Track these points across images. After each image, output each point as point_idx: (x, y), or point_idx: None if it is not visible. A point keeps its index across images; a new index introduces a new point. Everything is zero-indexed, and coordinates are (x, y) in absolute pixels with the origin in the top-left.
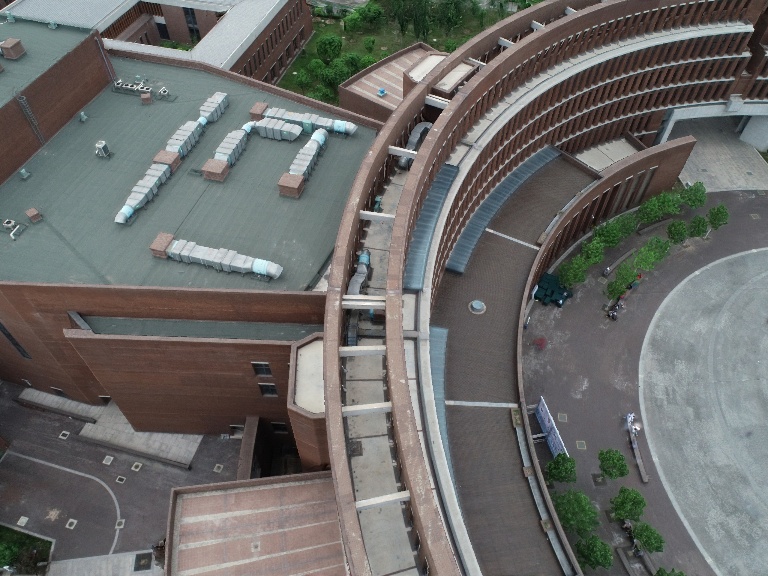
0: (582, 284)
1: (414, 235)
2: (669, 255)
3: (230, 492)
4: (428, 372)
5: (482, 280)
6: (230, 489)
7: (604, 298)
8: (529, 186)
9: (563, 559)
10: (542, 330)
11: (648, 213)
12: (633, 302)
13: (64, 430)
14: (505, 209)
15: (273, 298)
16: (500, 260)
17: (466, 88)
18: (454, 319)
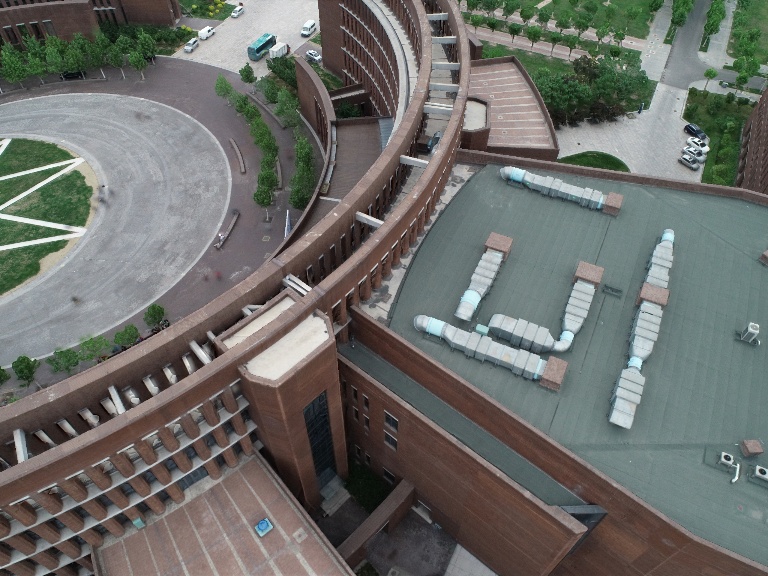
0: None
1: None
2: None
3: None
4: (398, 118)
5: None
6: None
7: None
8: None
9: (333, 131)
10: None
11: None
12: None
13: None
14: None
15: None
16: None
17: (268, 271)
18: None
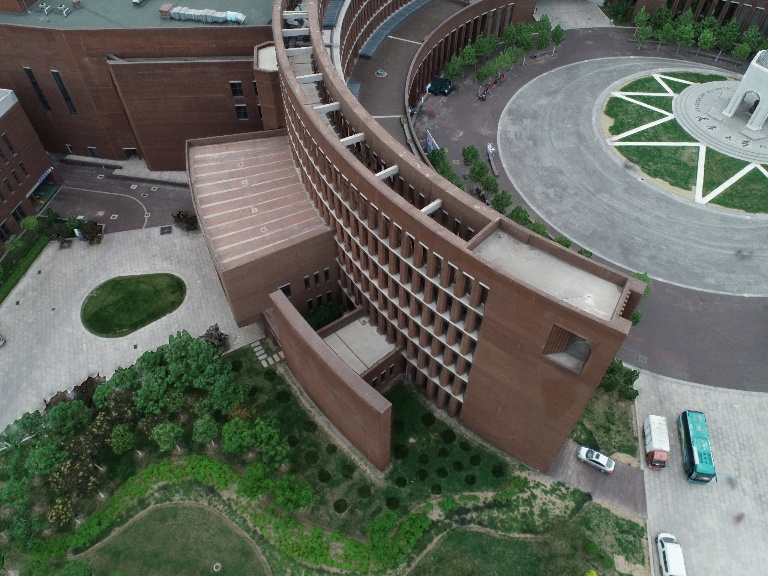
0: (463, 83)
1: (330, 4)
2: (526, 66)
3: (222, 145)
4: (338, 59)
5: (385, 61)
6: (222, 143)
7: (478, 90)
8: (420, 13)
9: None
10: (433, 108)
11: (508, 35)
12: (498, 91)
13: (100, 174)
14: (402, 26)
15: (241, 31)
16: (397, 51)
17: None
18: (365, 80)
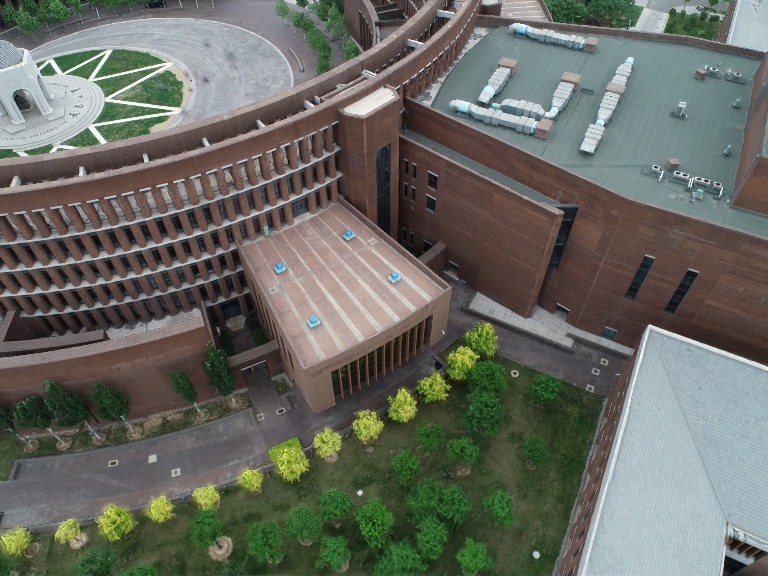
0: None
1: None
2: None
3: None
4: None
5: None
6: None
7: None
8: None
9: None
10: None
11: None
12: None
13: None
14: None
15: None
16: None
17: (353, 63)
18: None
